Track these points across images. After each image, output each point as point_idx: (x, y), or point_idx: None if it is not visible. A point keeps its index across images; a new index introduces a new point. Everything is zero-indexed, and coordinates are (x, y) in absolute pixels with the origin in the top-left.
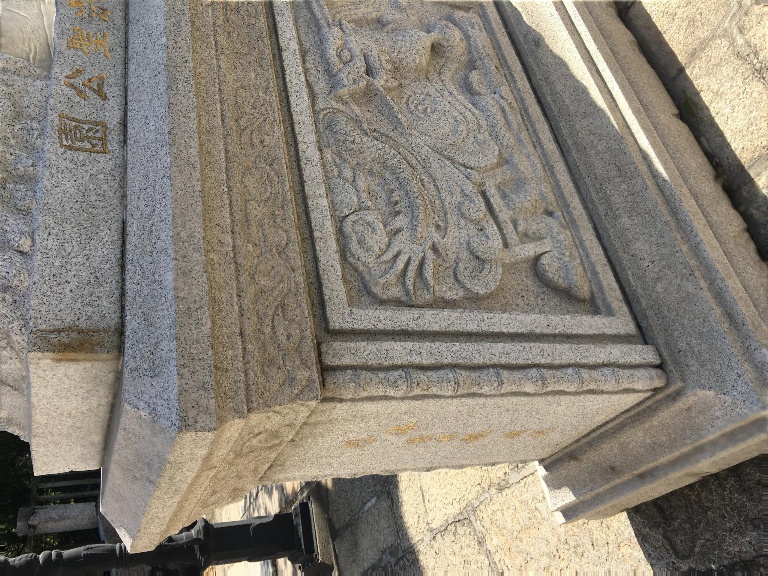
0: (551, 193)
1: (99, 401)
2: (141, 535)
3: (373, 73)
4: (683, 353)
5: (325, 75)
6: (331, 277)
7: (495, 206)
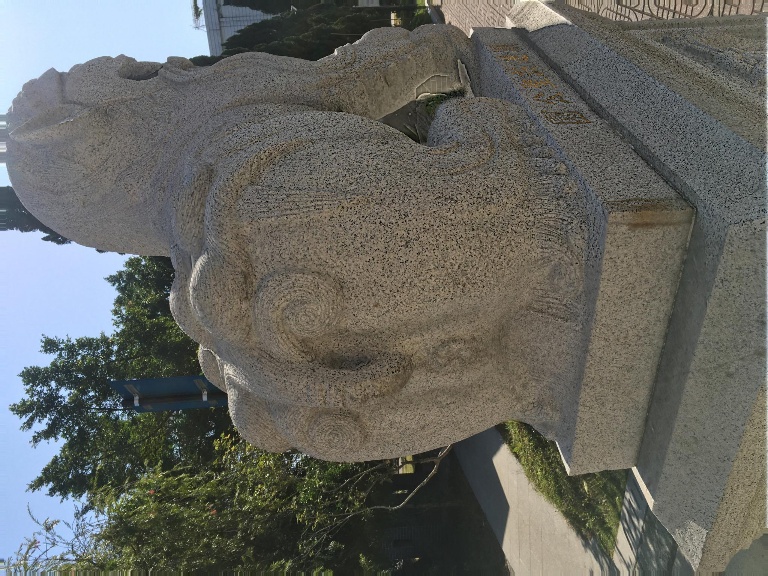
0: None
1: (658, 311)
2: (721, 515)
3: None
4: None
5: (739, 78)
6: None
7: None
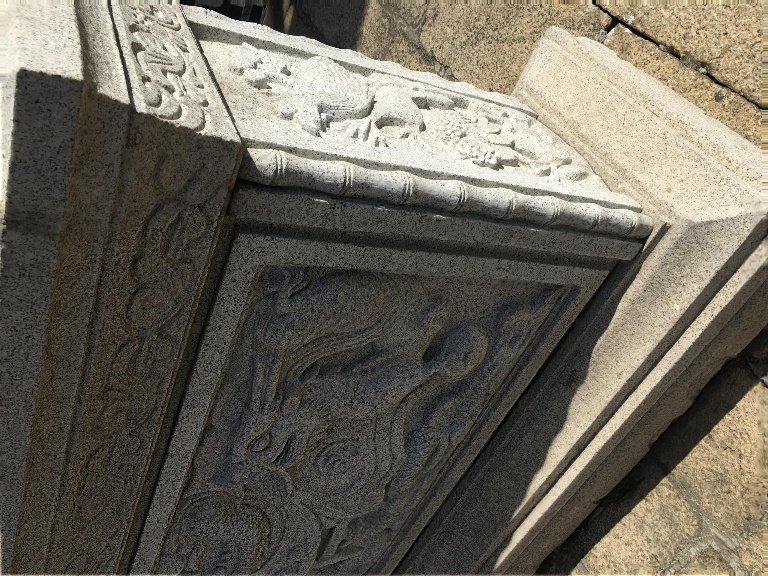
0: (405, 519)
1: None
2: None
3: (287, 455)
4: None
5: (221, 456)
6: None
7: (333, 537)
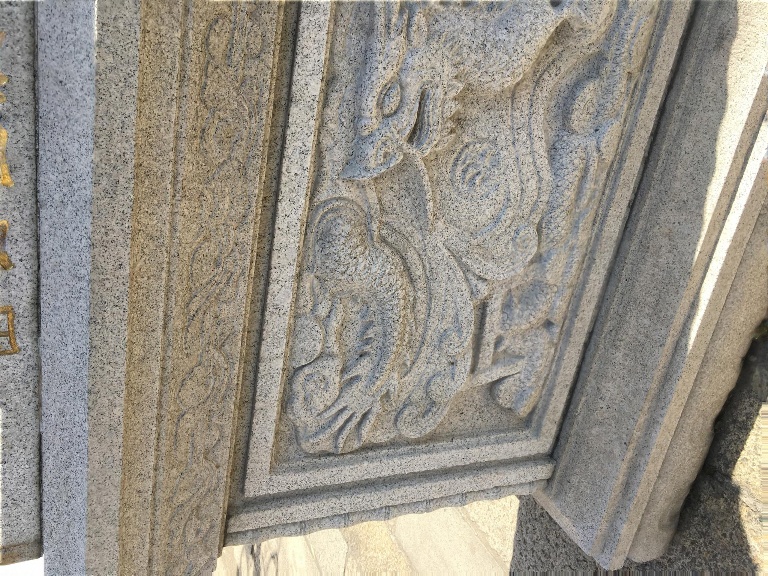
0: (566, 302)
1: None
2: None
3: (422, 132)
4: (570, 485)
5: (349, 131)
6: (260, 450)
7: (487, 326)
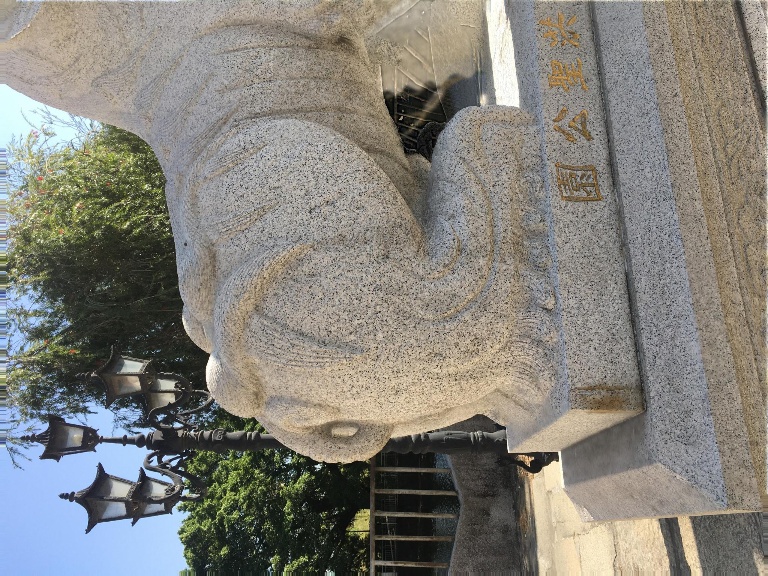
0: None
1: (598, 427)
2: None
3: None
4: None
5: None
6: None
7: None
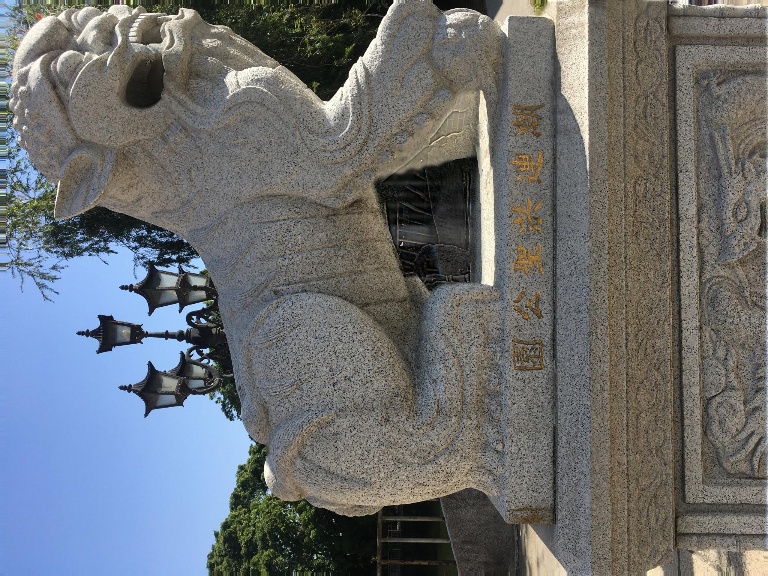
0: None
1: None
2: None
3: (767, 229)
4: None
5: (717, 235)
6: (693, 461)
7: None
